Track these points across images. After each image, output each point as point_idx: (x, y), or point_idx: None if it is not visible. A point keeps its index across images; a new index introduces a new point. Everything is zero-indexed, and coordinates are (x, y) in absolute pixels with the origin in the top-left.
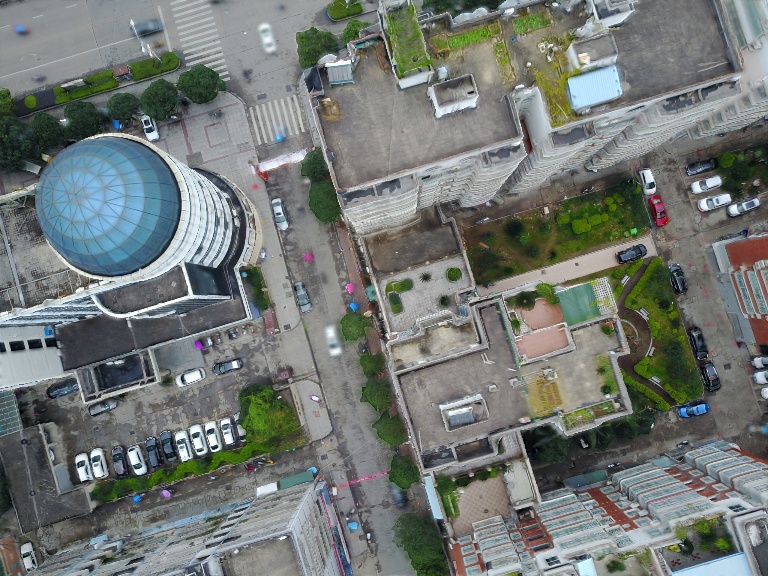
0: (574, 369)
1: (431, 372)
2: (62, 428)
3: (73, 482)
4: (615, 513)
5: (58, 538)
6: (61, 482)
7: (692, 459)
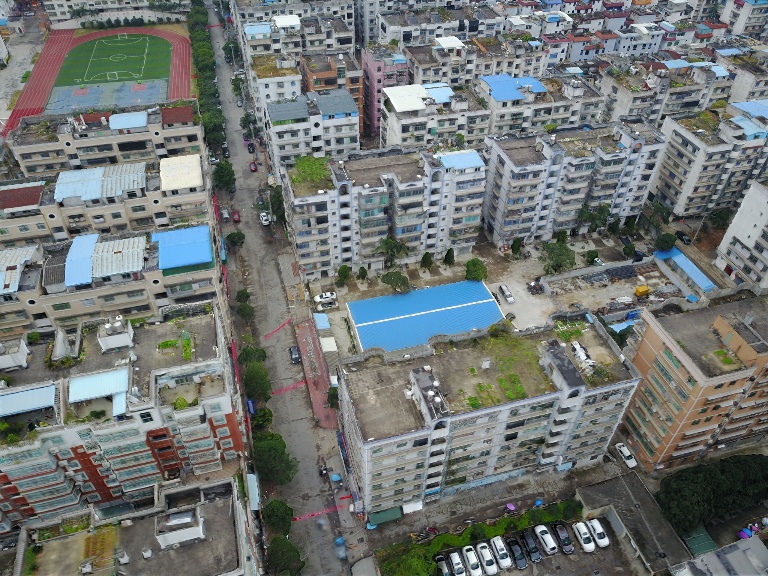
0: (60, 573)
1: (205, 573)
2: (633, 574)
3: (606, 520)
4: (89, 467)
5: (606, 472)
6: (616, 518)
7: (4, 523)
